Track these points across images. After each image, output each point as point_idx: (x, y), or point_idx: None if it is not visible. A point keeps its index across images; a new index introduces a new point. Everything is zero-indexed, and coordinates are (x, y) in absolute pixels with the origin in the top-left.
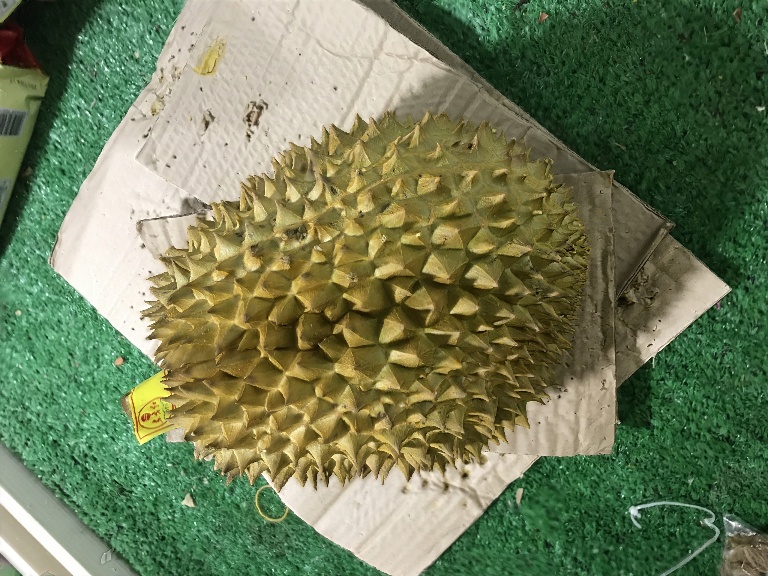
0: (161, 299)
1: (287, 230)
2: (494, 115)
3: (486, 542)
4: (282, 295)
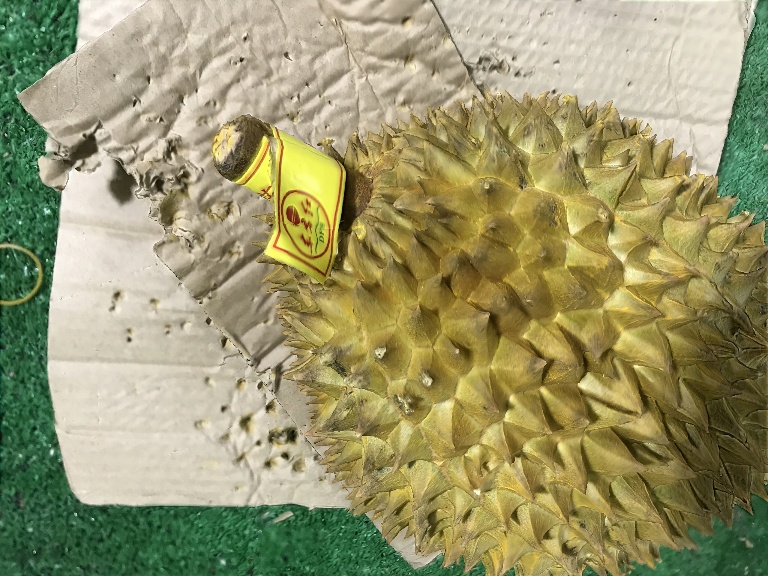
0: (562, 173)
1: None
2: None
3: (200, 524)
4: (677, 364)
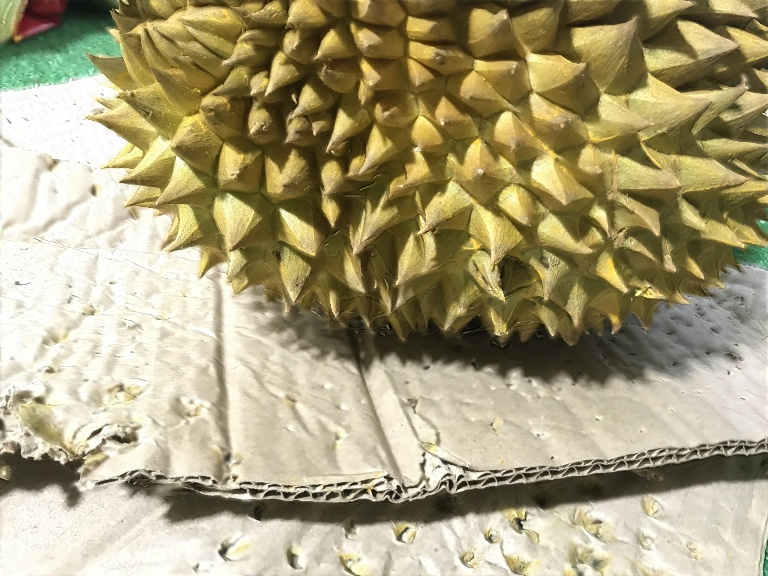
0: None
1: None
2: None
3: None
4: None
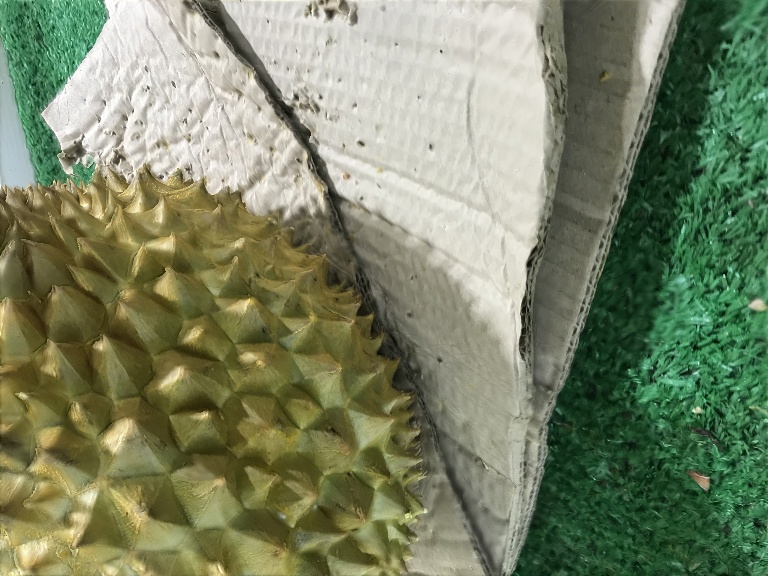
0: None
1: None
2: None
3: None
4: None
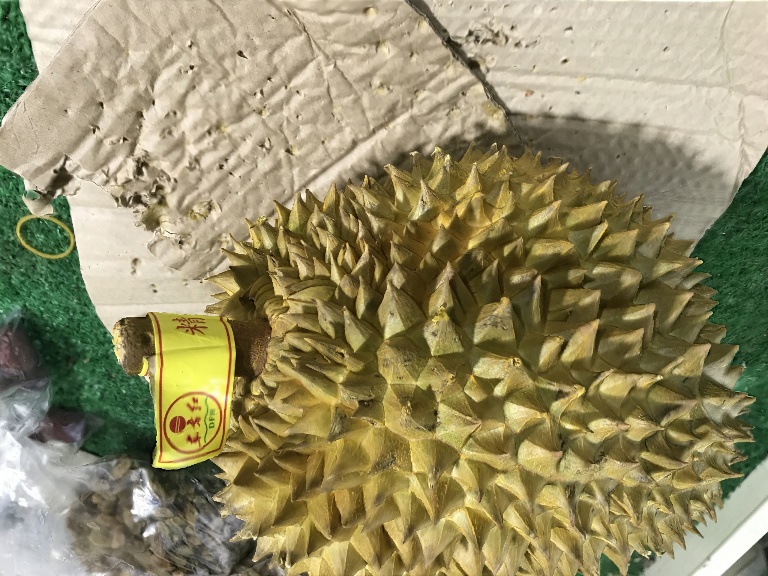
0: (404, 429)
1: (608, 493)
2: (690, 238)
3: None
4: None
